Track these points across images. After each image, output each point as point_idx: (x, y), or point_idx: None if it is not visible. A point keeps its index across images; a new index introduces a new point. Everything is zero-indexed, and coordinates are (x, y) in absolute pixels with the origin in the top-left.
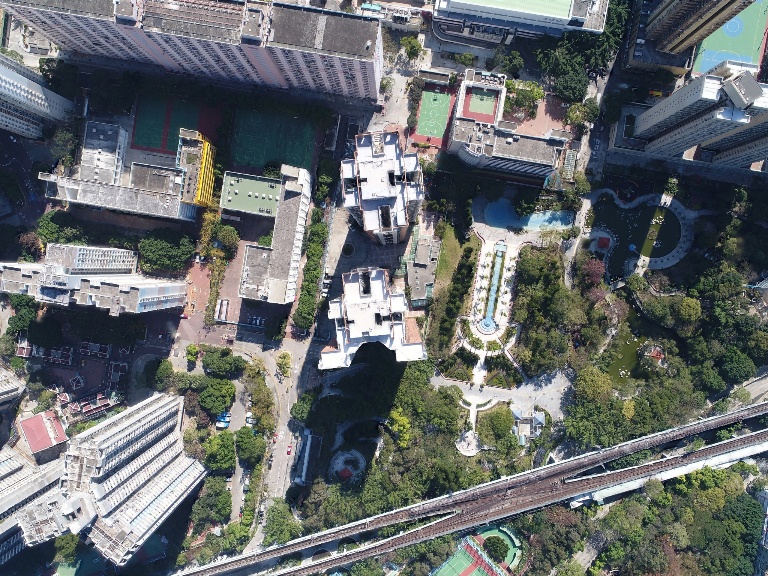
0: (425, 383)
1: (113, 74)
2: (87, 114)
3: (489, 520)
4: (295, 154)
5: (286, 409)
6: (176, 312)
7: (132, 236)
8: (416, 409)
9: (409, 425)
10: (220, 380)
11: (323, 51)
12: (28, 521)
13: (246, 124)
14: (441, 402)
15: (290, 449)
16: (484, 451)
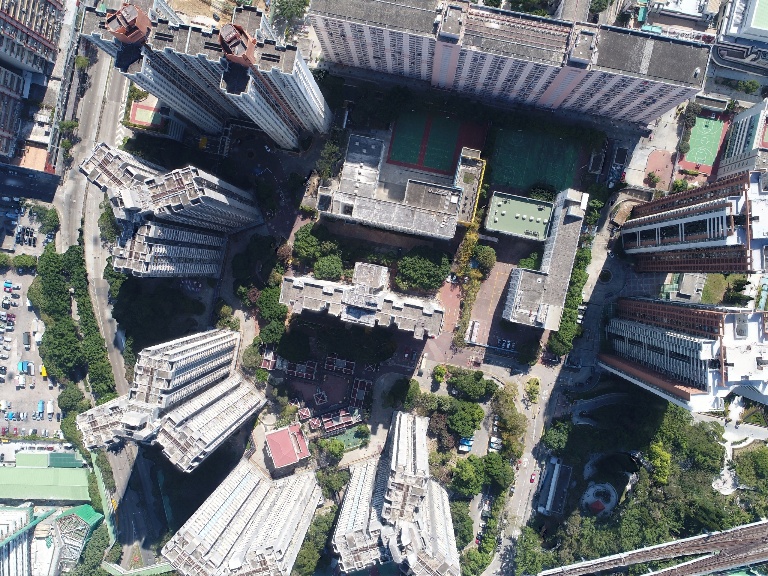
0: (689, 418)
1: (376, 87)
2: (345, 127)
3: (749, 563)
4: (556, 176)
5: (531, 436)
6: None
7: (390, 253)
8: (677, 444)
9: (669, 460)
10: (472, 404)
11: (648, 77)
12: (347, 547)
13: (507, 143)
14: (703, 438)
15: (534, 477)
16: (739, 490)
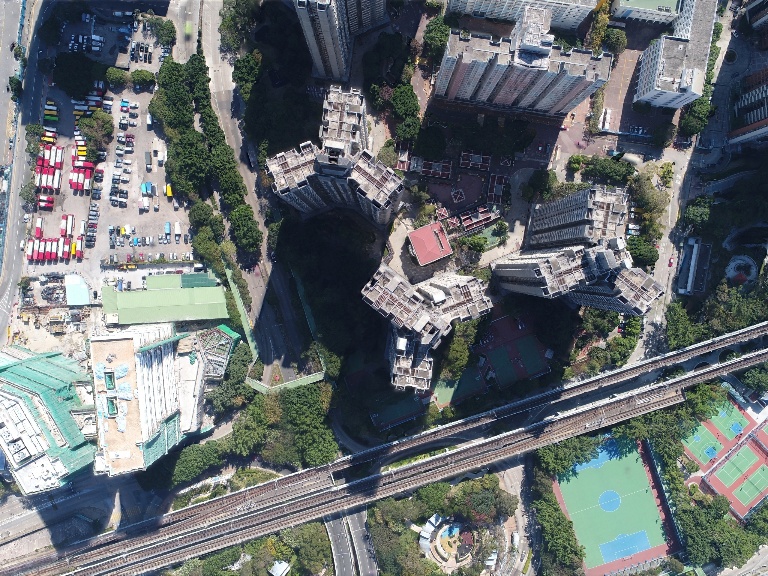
0: None
1: None
2: None
3: None
4: None
5: (667, 220)
6: (555, 123)
7: None
8: None
9: None
10: (612, 186)
11: None
12: (551, 272)
13: None
14: None
15: (673, 260)
16: None
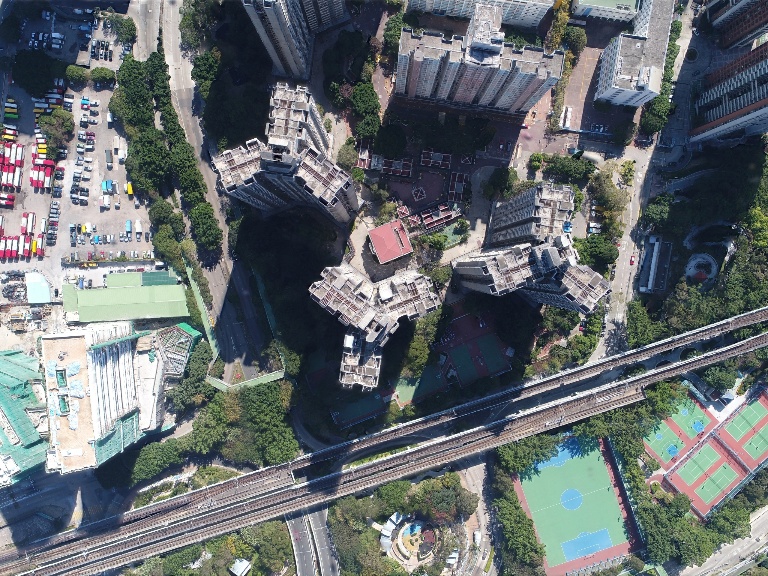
0: None
1: None
2: None
3: None
4: None
5: (629, 219)
6: (517, 121)
7: None
8: None
9: None
10: (572, 185)
11: None
12: (498, 269)
13: None
14: None
15: (634, 258)
16: None
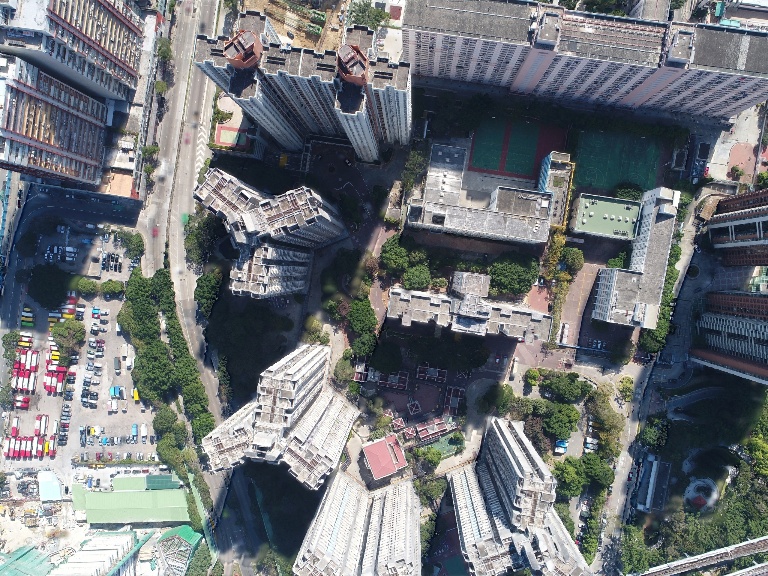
0: None
1: (455, 96)
2: (425, 137)
3: None
4: (638, 174)
5: (627, 434)
6: None
7: (479, 260)
8: None
9: None
10: (568, 405)
11: (746, 72)
12: (478, 557)
13: (587, 144)
14: None
15: (632, 475)
16: None
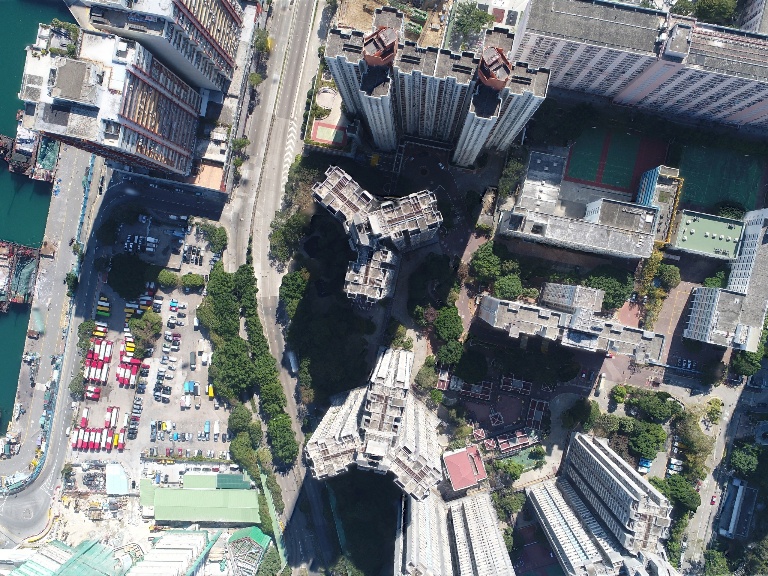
0: None
1: (557, 104)
2: None
3: None
4: (739, 193)
5: (712, 457)
6: (601, 351)
7: (573, 272)
8: None
9: None
10: (656, 425)
11: None
12: None
13: (688, 160)
14: None
15: (715, 499)
16: None
